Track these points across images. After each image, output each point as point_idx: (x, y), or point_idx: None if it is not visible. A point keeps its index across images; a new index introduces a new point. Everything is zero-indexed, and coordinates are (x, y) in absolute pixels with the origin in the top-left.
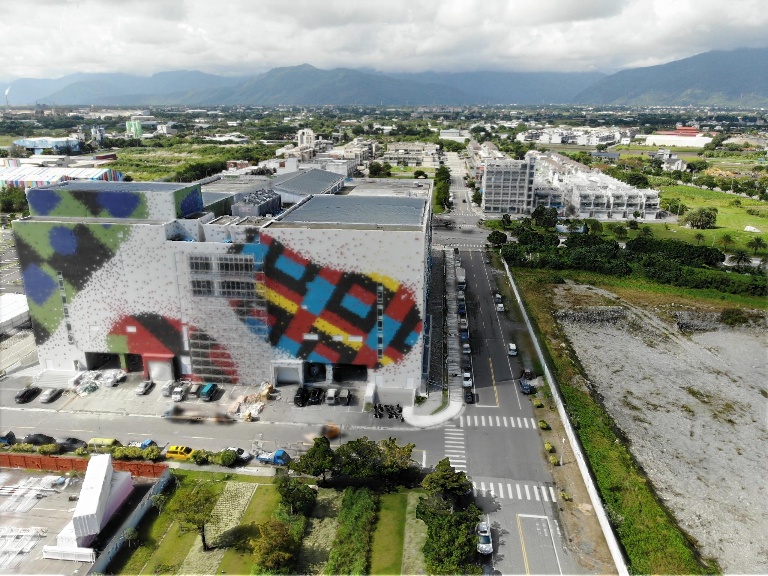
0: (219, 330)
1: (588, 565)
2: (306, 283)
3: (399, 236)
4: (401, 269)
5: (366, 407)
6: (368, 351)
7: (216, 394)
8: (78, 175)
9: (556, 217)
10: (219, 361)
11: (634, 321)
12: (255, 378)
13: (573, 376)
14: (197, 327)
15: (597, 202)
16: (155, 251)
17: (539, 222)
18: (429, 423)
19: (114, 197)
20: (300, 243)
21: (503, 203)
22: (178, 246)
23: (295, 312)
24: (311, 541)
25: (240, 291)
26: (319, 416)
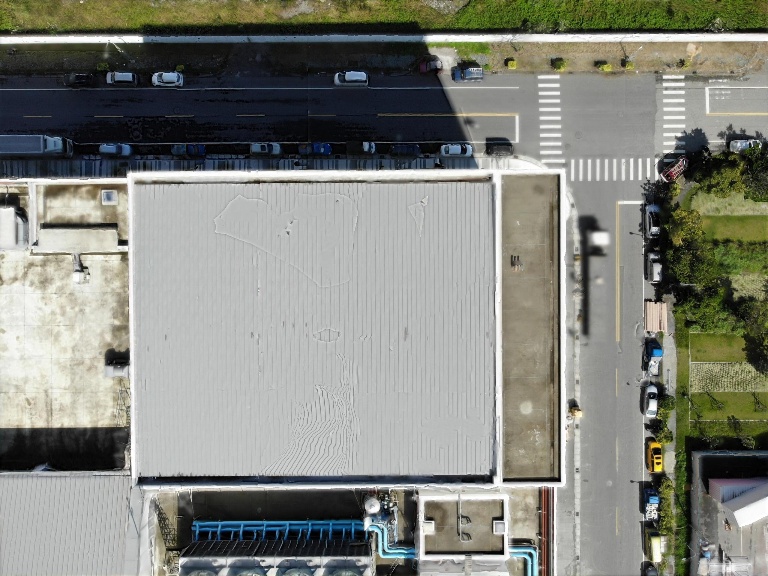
0: None
1: (760, 64)
2: None
3: None
4: None
5: None
6: None
7: None
8: None
9: None
10: None
11: None
12: None
13: (425, 4)
14: None
15: None
16: None
17: None
18: None
19: None
20: None
21: None
22: None
23: None
24: (760, 294)
25: None
26: None
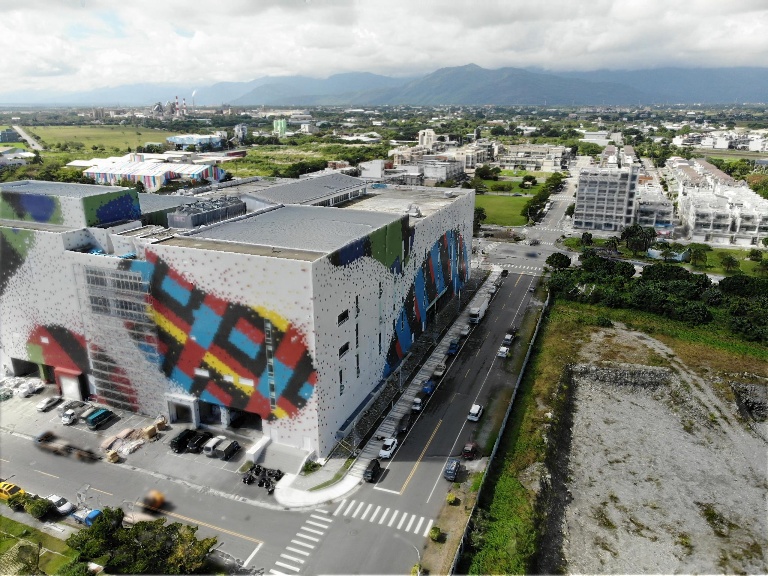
0: (117, 352)
1: None
2: (193, 310)
3: (283, 265)
4: (288, 305)
5: (244, 466)
6: (260, 398)
7: (108, 422)
8: (183, 171)
9: (653, 239)
10: (117, 386)
11: (677, 391)
12: (153, 409)
13: (531, 464)
14: (97, 346)
15: (718, 223)
16: (56, 261)
17: (630, 244)
18: (298, 502)
19: (34, 200)
20: (183, 264)
21: (596, 218)
22: (75, 257)
23: (185, 342)
24: None
25: (132, 312)
26: (186, 469)
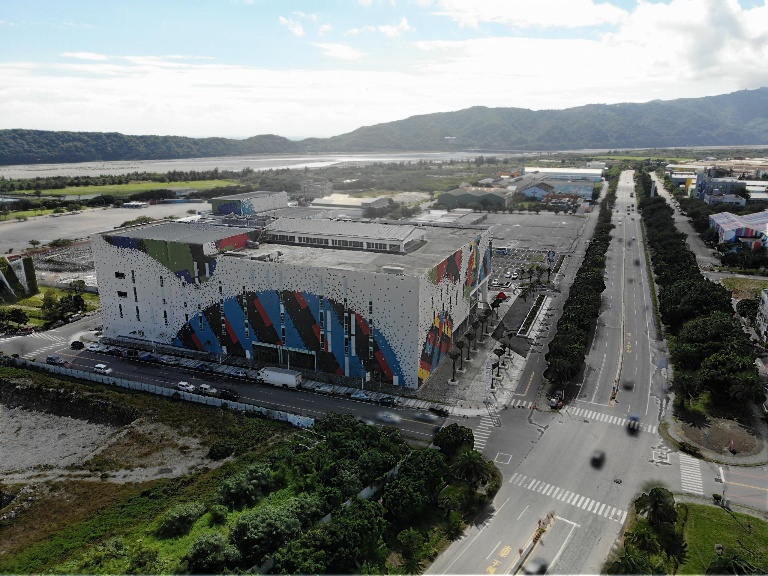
0: None
1: None
2: None
3: None
4: None
5: None
6: None
7: None
8: None
9: None
10: None
11: None
12: None
13: None
14: None
15: None
16: None
17: None
18: (77, 335)
19: None
20: None
21: None
22: None
23: None
24: None
25: None
26: None
